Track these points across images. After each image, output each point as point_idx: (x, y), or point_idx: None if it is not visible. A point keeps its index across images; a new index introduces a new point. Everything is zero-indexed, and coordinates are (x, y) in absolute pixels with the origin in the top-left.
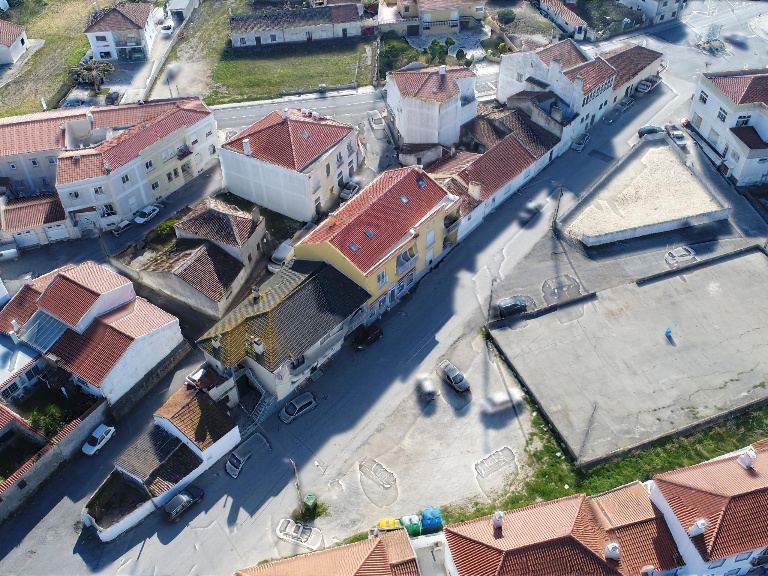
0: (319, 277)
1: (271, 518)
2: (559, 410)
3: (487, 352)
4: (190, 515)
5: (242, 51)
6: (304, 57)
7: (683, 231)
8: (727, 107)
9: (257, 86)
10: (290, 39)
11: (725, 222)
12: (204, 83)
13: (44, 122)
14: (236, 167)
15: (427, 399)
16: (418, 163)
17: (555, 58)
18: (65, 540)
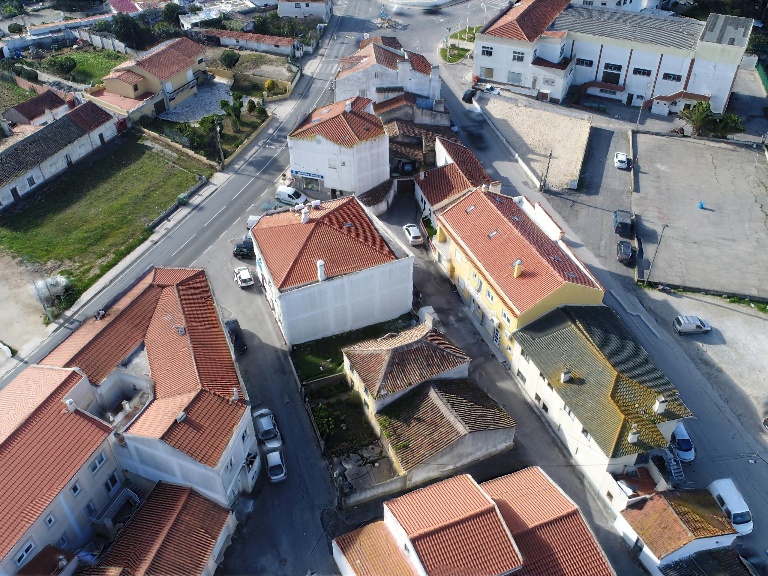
0: (580, 321)
1: None
2: (757, 291)
3: (668, 295)
4: None
5: (5, 216)
6: (96, 184)
7: (591, 147)
8: (522, 48)
9: (104, 238)
10: (49, 174)
11: (594, 128)
12: (28, 273)
13: (29, 424)
14: (308, 305)
15: (704, 355)
16: (387, 207)
17: (402, 59)
18: None
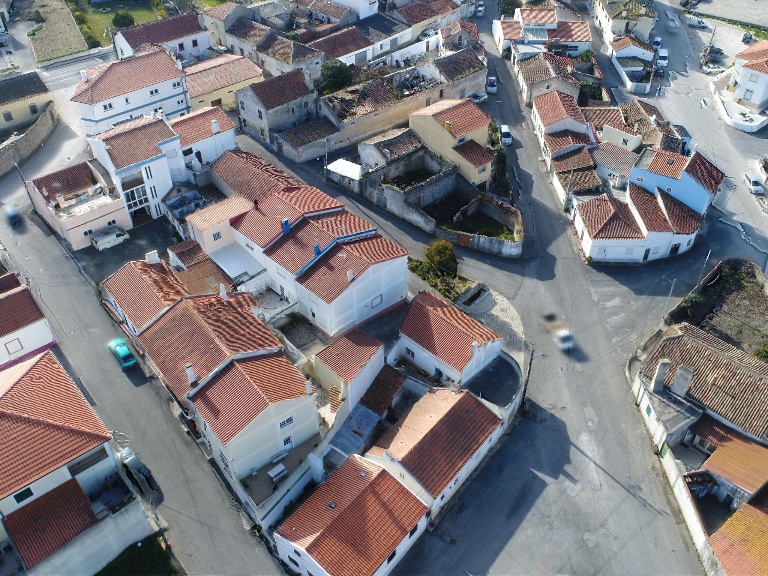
0: None
1: (696, 71)
2: None
3: None
4: (666, 78)
5: None
6: None
7: None
8: None
9: None
10: None
11: None
12: None
13: None
14: None
15: (696, 33)
16: None
17: None
18: (632, 96)
